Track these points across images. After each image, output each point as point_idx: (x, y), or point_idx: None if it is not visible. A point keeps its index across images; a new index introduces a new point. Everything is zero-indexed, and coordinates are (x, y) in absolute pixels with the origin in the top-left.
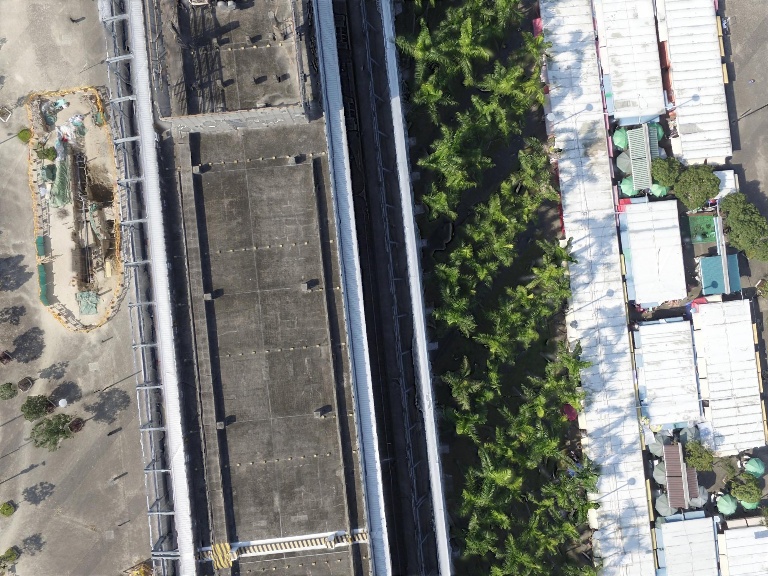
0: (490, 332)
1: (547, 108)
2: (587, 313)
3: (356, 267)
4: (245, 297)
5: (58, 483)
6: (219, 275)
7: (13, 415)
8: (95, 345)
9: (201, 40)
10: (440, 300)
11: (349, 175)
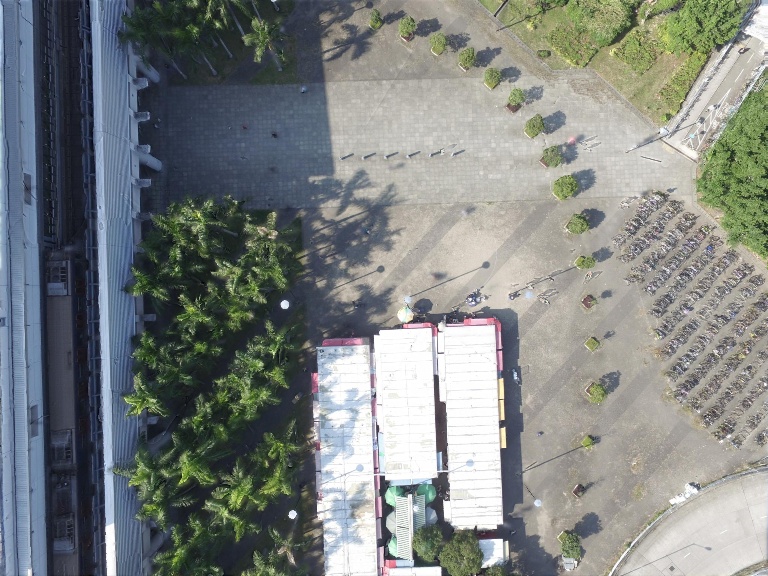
0: None
1: (318, 465)
2: None
3: None
4: None
5: None
6: None
7: None
8: None
9: None
10: None
11: None
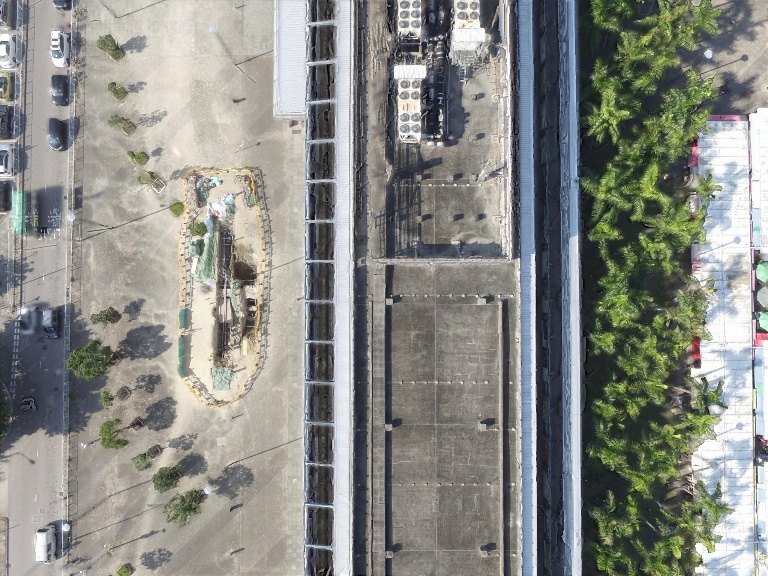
0: (635, 468)
1: None
2: (715, 444)
3: (532, 410)
4: (422, 429)
5: (176, 551)
6: (399, 405)
7: (139, 480)
8: (225, 420)
9: (403, 173)
10: (592, 435)
11: (534, 319)
